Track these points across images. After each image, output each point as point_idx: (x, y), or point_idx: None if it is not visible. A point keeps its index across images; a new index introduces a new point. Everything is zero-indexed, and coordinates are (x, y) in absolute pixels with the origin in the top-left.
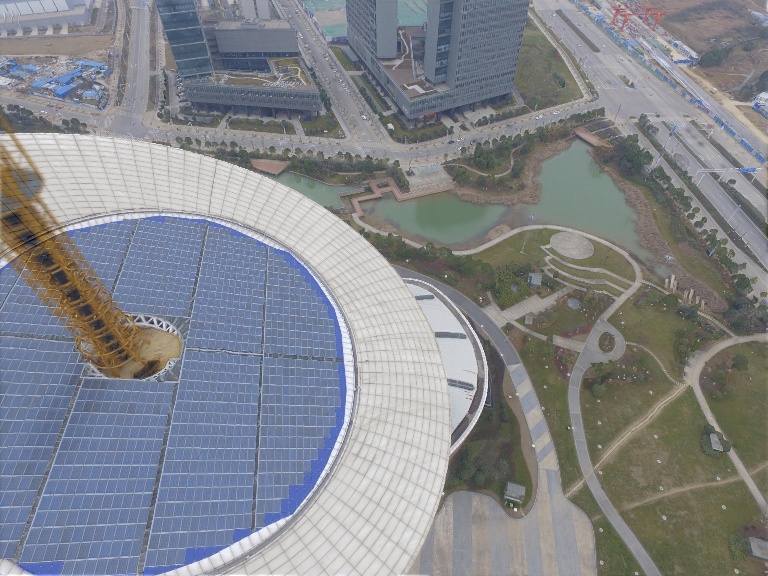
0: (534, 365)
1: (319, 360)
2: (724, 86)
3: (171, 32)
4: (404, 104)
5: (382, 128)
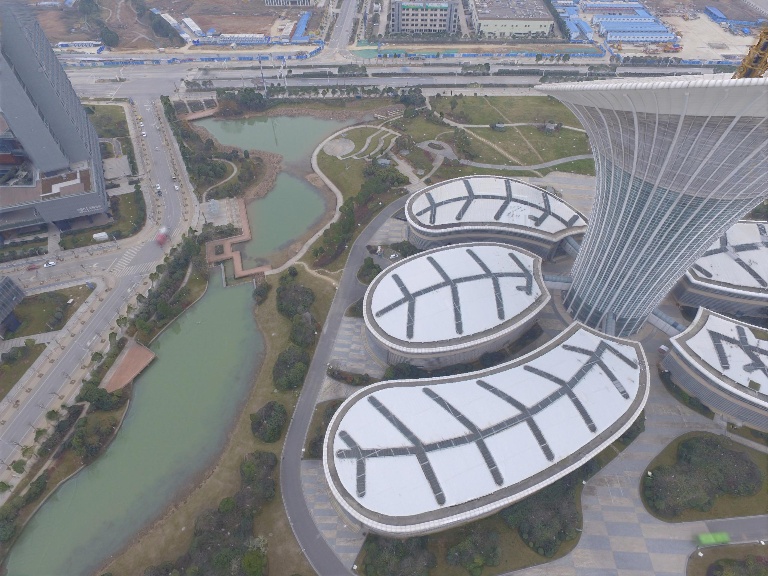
0: (459, 175)
1: None
2: (153, 47)
3: None
4: (81, 205)
5: (92, 247)
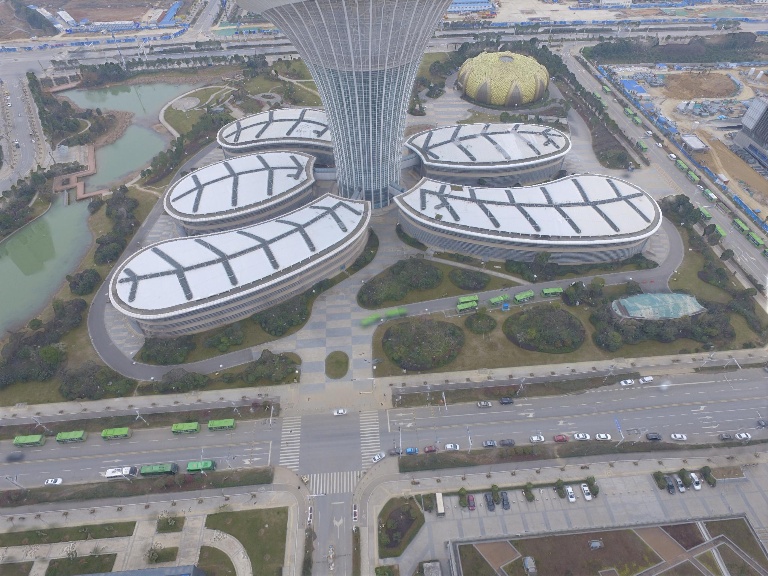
0: None
1: None
2: (28, 37)
3: None
4: None
5: None
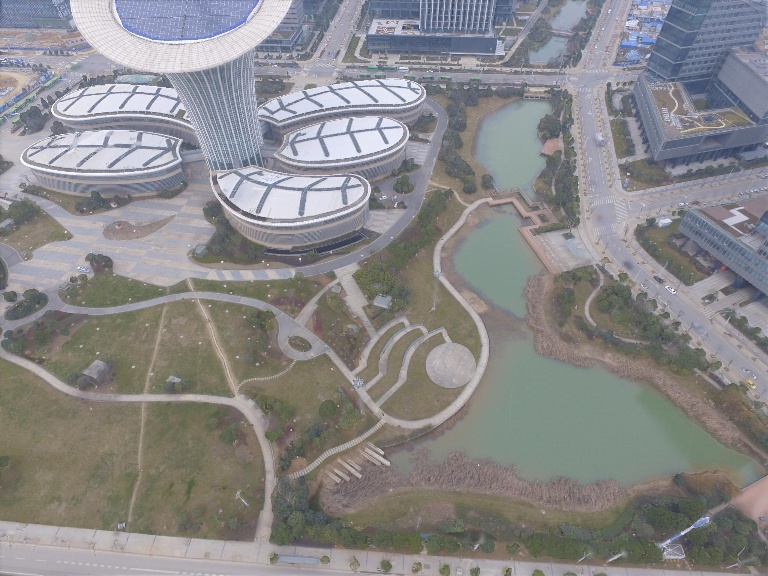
0: None
1: (182, 33)
2: None
3: (668, 25)
4: None
5: None
